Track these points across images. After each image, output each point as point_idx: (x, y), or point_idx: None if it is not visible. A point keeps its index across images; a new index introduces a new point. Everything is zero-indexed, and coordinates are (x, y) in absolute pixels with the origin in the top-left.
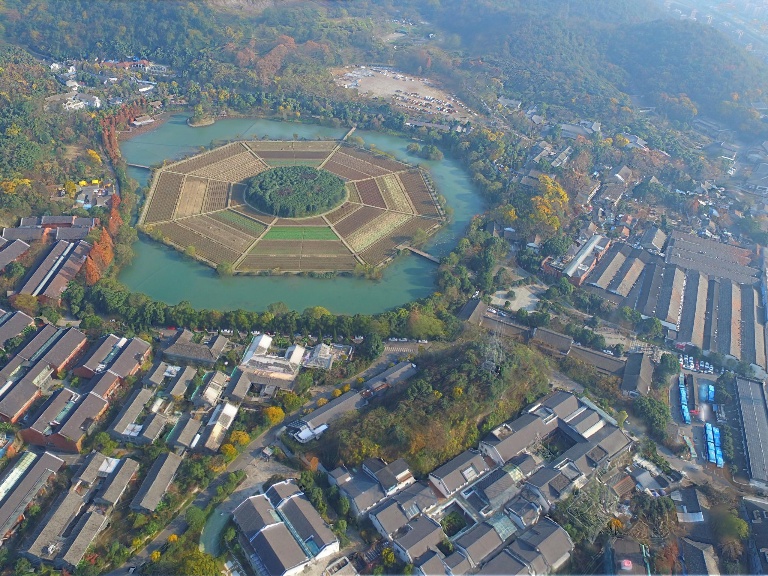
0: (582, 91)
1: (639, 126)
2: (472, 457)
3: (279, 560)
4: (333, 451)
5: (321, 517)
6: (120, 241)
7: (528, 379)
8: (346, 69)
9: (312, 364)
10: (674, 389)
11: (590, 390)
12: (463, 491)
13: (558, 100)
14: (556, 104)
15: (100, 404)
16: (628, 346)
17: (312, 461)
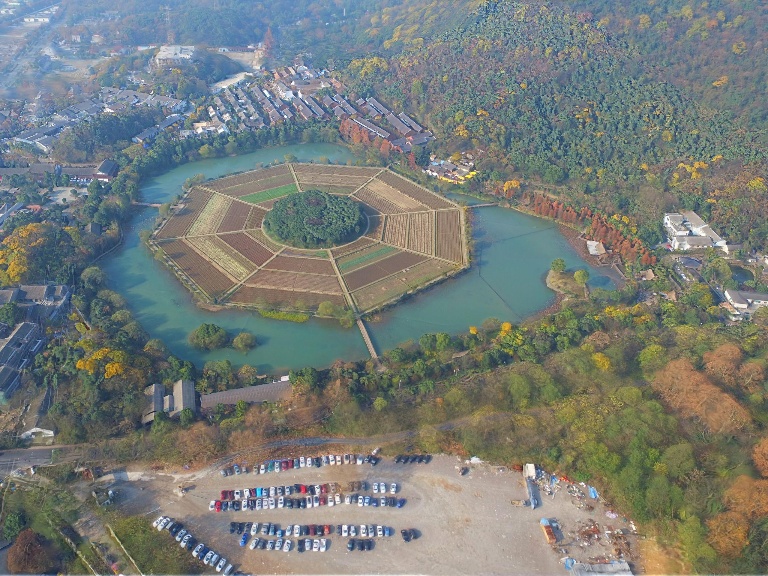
0: None
1: None
2: None
3: None
4: None
5: None
6: None
7: None
8: None
9: None
10: None
11: None
12: None
13: None
14: None
15: None
16: None
17: None
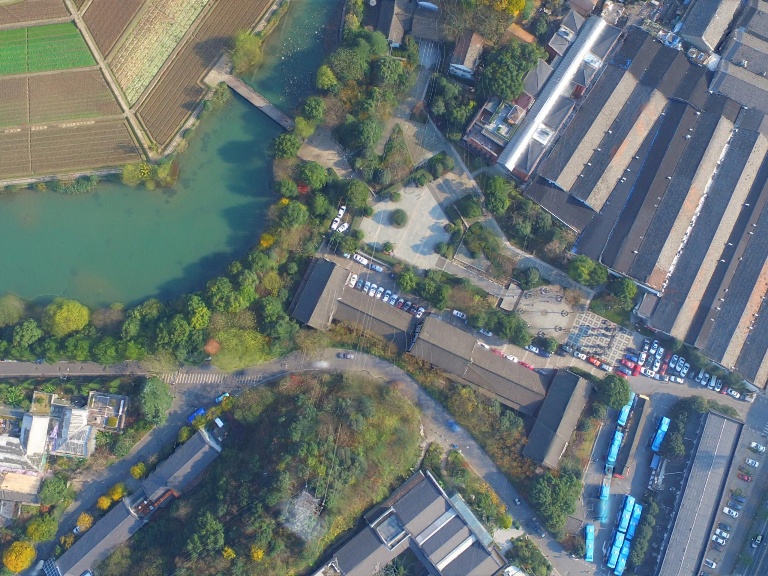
0: None
1: None
2: None
3: None
4: None
5: None
6: None
7: None
8: None
9: (62, 450)
10: (609, 423)
11: (479, 444)
12: None
13: None
14: None
15: None
16: (569, 328)
17: None
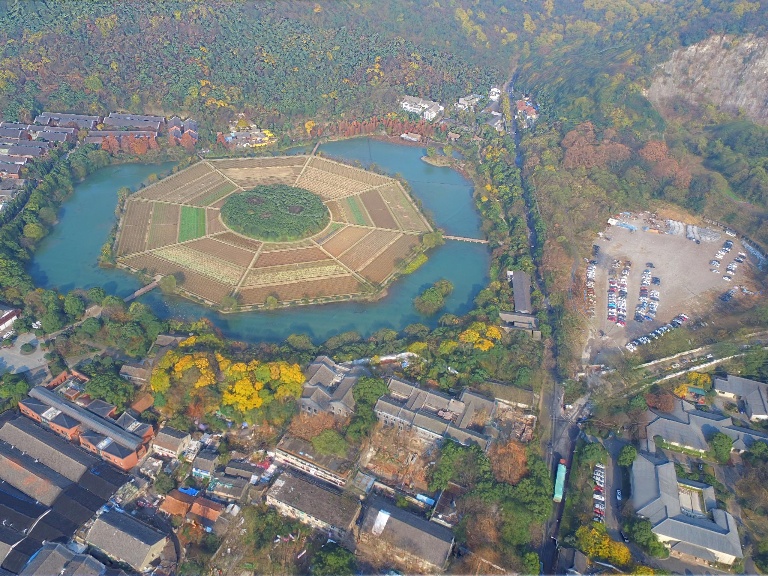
0: None
1: None
2: None
3: None
4: None
5: None
6: None
7: None
8: (700, 221)
9: None
10: None
11: None
12: None
13: None
14: None
15: None
16: None
17: None
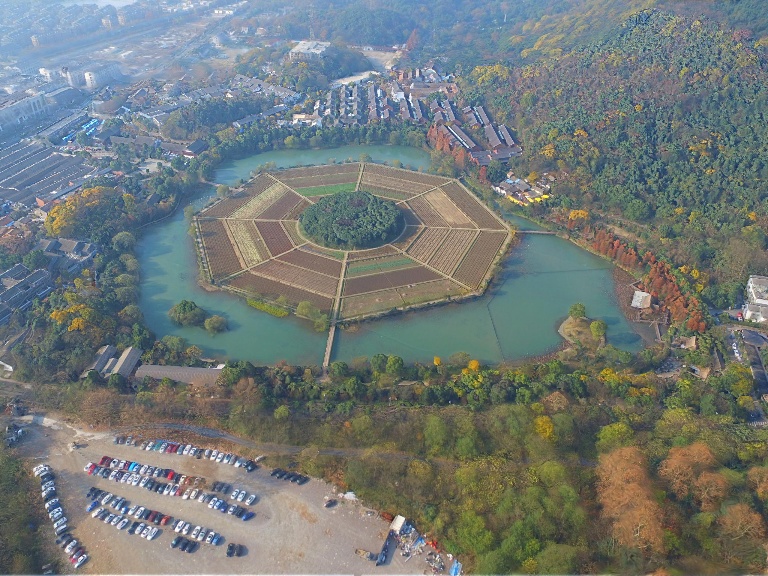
0: None
1: None
2: None
3: None
4: None
5: None
6: None
7: None
8: None
9: None
10: None
11: None
12: None
13: None
14: None
15: None
16: None
17: None
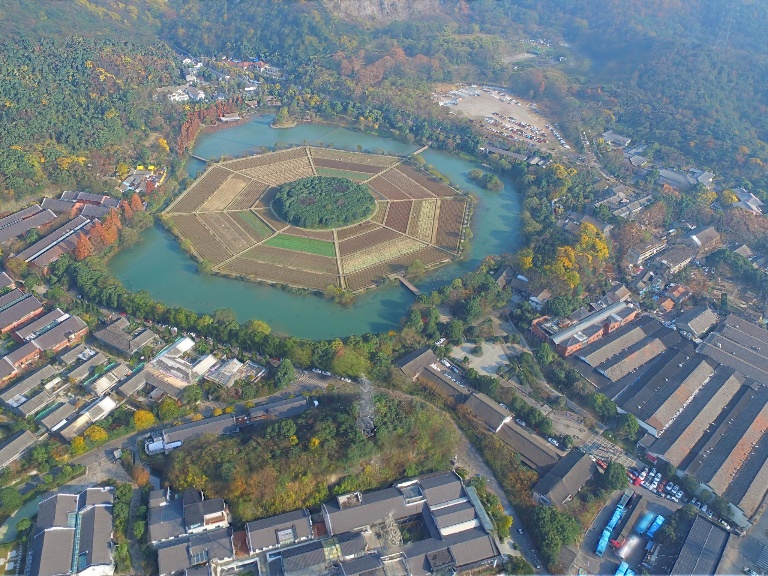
0: (707, 134)
1: (765, 183)
2: (298, 518)
3: (39, 565)
4: (169, 471)
5: (115, 535)
6: (133, 225)
7: (416, 449)
8: (455, 86)
9: (213, 377)
10: (610, 507)
11: (498, 480)
12: (270, 553)
13: (674, 142)
14: (670, 146)
15: (8, 370)
16: (584, 440)
17: (140, 475)
